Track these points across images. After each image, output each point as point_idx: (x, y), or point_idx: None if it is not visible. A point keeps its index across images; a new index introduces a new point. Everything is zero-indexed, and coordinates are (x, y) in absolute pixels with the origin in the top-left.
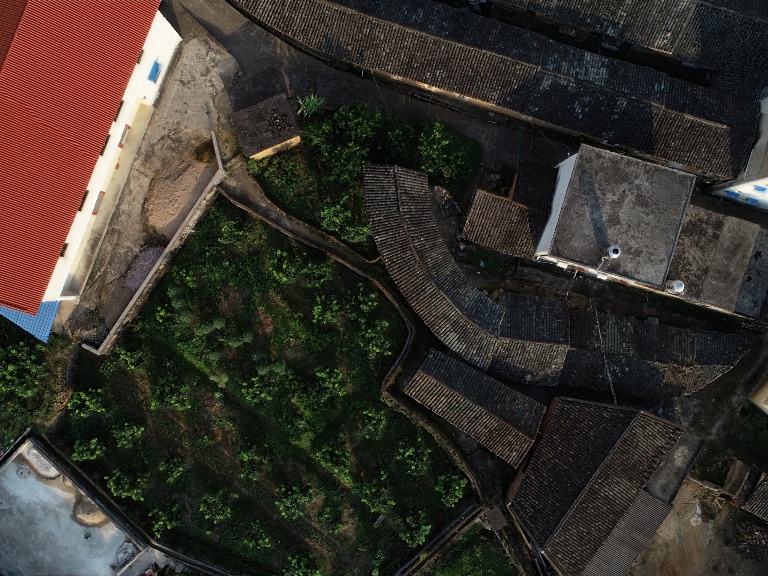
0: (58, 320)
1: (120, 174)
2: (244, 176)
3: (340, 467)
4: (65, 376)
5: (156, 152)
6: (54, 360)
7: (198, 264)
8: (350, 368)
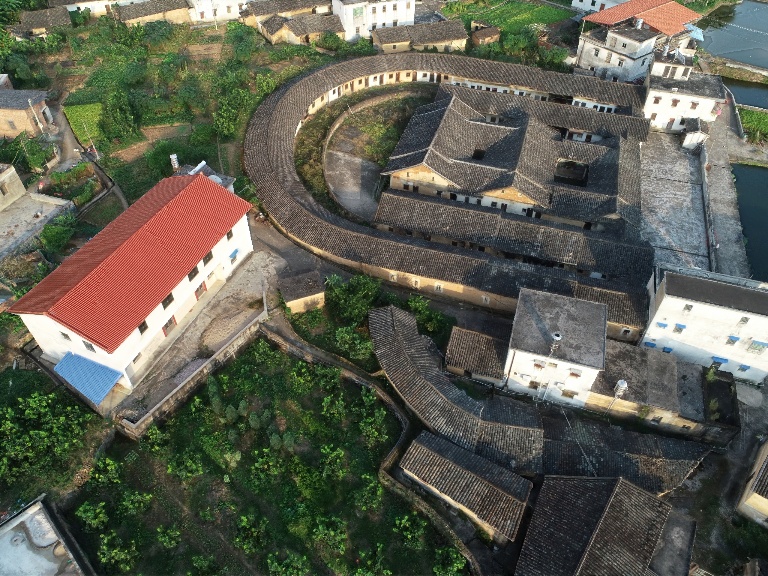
0: (108, 407)
1: (191, 315)
2: (281, 320)
3: None
4: (95, 454)
5: (221, 304)
6: (92, 437)
7: (233, 379)
8: (351, 459)
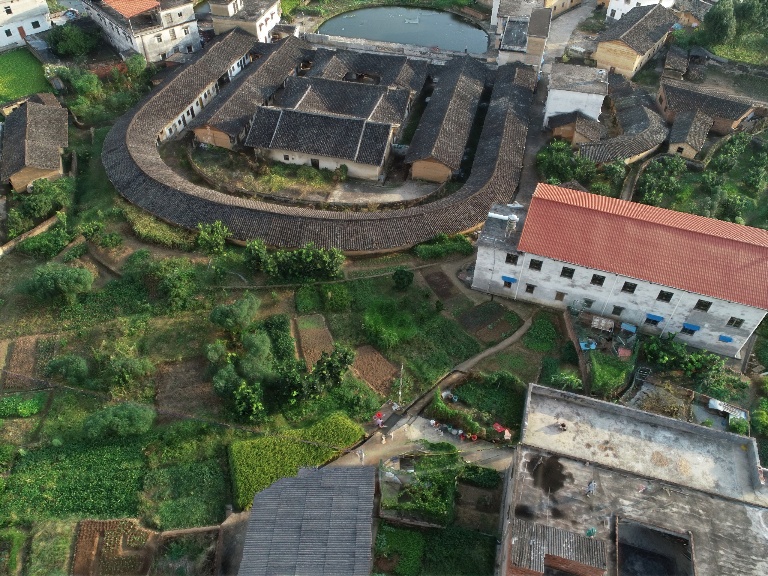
0: None
1: None
2: None
3: (760, 169)
4: None
5: None
6: None
7: None
8: (696, 181)
